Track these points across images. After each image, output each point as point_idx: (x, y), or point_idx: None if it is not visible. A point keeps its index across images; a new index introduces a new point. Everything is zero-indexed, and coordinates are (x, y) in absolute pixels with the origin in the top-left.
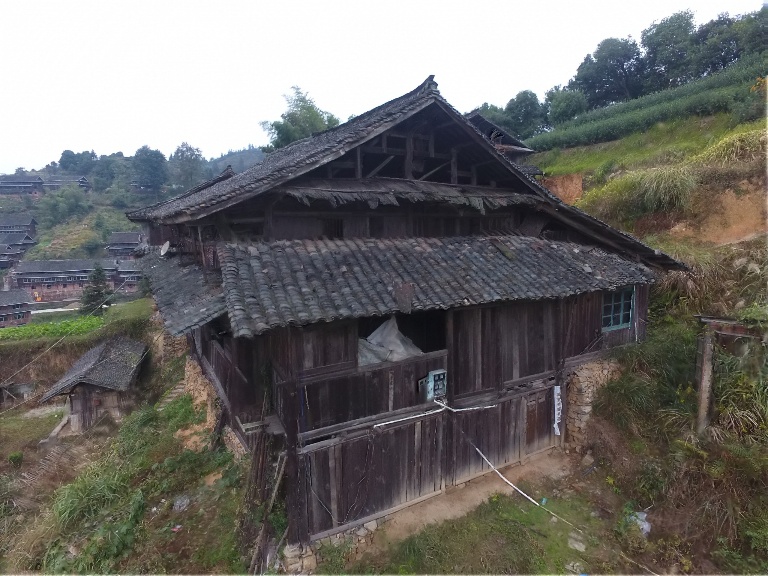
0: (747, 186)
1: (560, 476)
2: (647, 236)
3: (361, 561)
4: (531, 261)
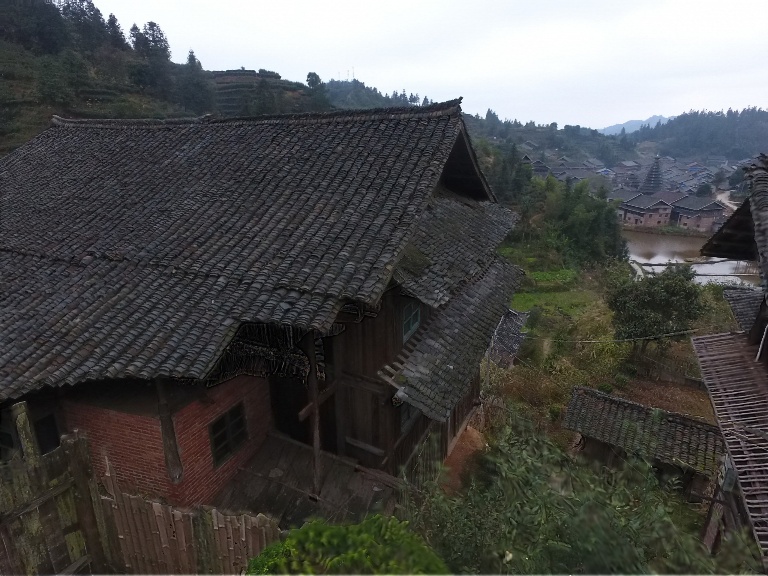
0: None
1: None
2: None
3: None
4: None
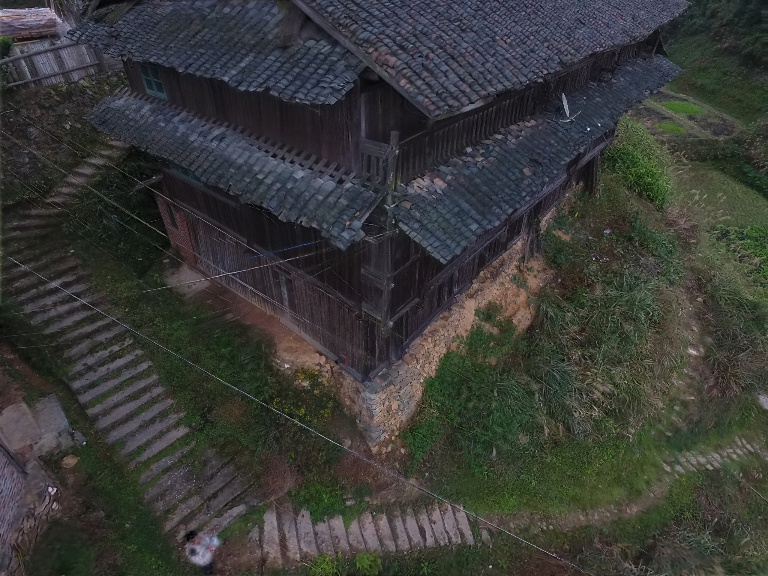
0: None
1: None
2: None
3: None
4: None
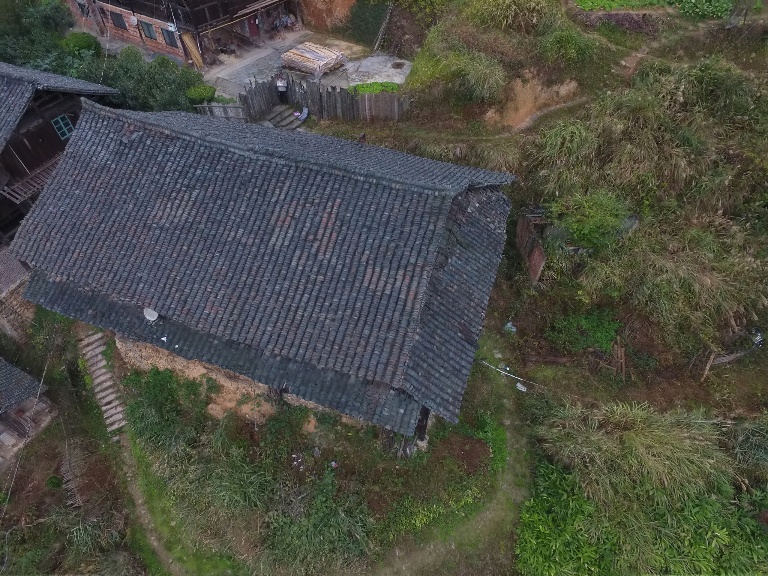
0: (528, 75)
1: None
2: (472, 121)
3: (437, 421)
4: (473, 241)
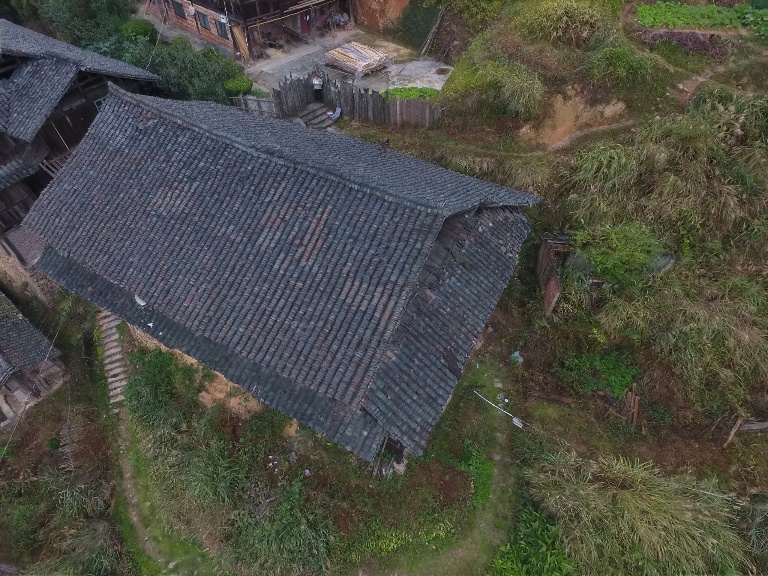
0: (571, 92)
1: (480, 346)
2: (504, 136)
3: None
4: (478, 262)
